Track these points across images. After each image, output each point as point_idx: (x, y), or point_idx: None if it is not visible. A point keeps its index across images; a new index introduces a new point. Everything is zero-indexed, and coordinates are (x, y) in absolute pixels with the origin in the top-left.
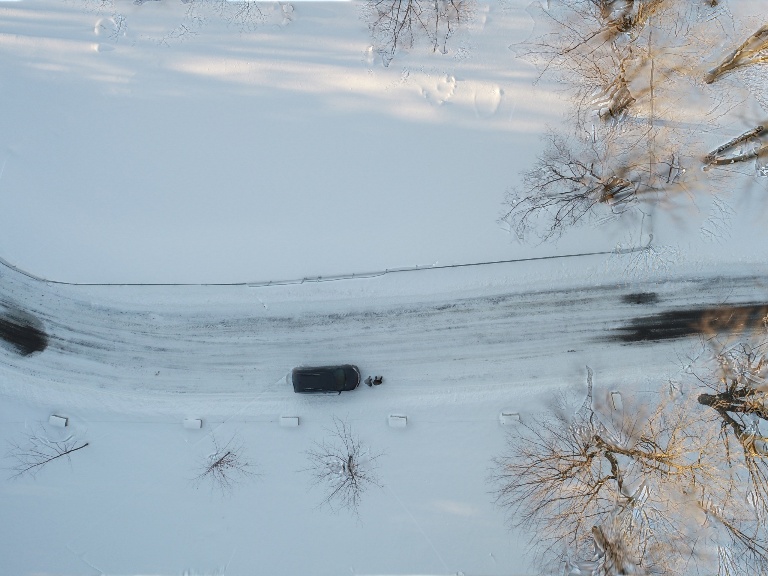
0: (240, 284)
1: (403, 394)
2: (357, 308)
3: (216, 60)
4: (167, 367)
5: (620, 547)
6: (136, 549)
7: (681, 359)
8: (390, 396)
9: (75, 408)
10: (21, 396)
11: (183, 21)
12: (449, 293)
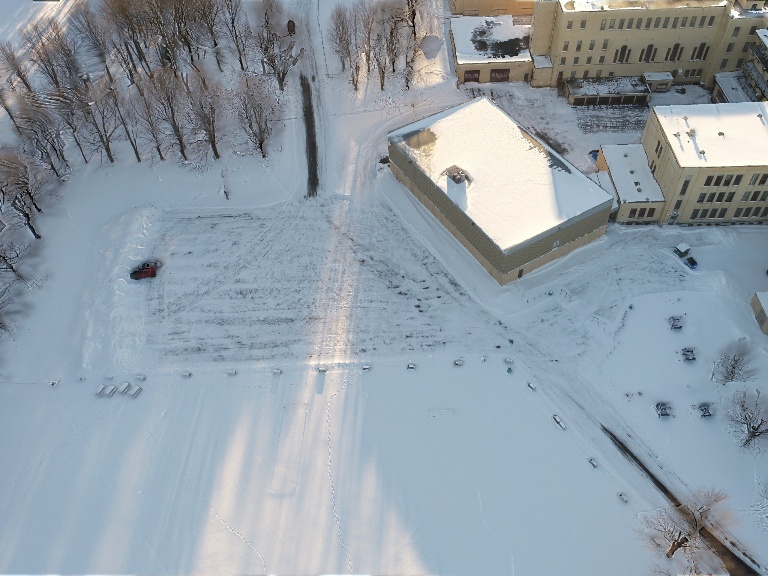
0: None
1: (287, 40)
2: None
3: None
4: (296, 7)
5: (248, 28)
6: None
7: (295, 86)
8: (286, 37)
9: None
10: None
11: (392, 7)
12: None
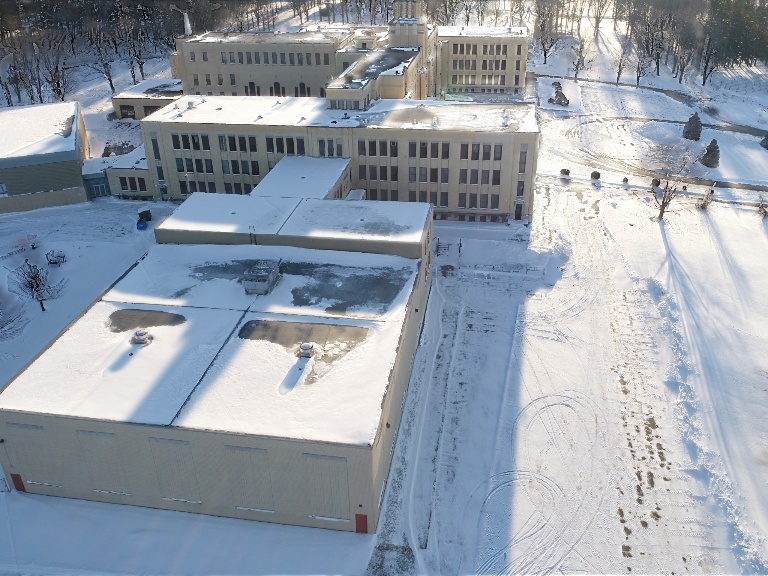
0: None
1: None
2: None
3: (113, 81)
4: None
5: None
6: (4, 62)
7: None
8: None
9: None
10: None
11: None
12: None
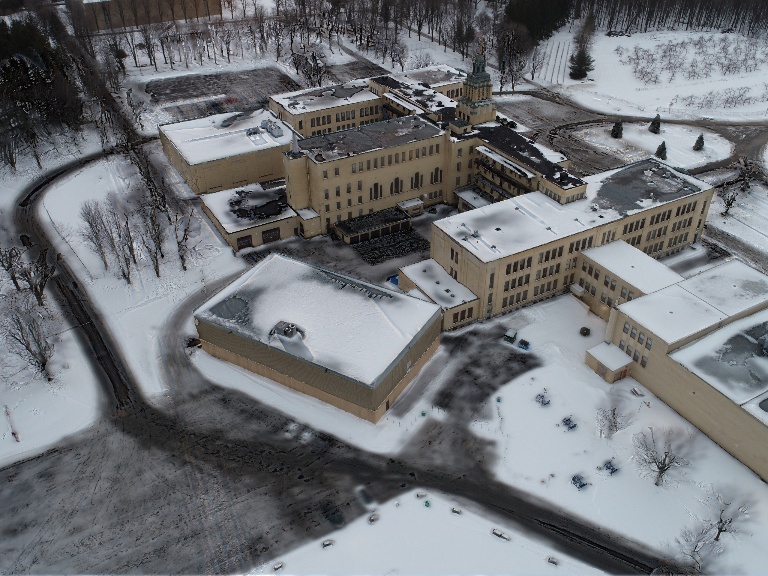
0: (53, 223)
1: None
2: (53, 242)
3: None
4: None
5: None
6: None
7: (56, 297)
8: (24, 252)
9: (5, 214)
10: (7, 207)
11: None
12: (63, 253)
